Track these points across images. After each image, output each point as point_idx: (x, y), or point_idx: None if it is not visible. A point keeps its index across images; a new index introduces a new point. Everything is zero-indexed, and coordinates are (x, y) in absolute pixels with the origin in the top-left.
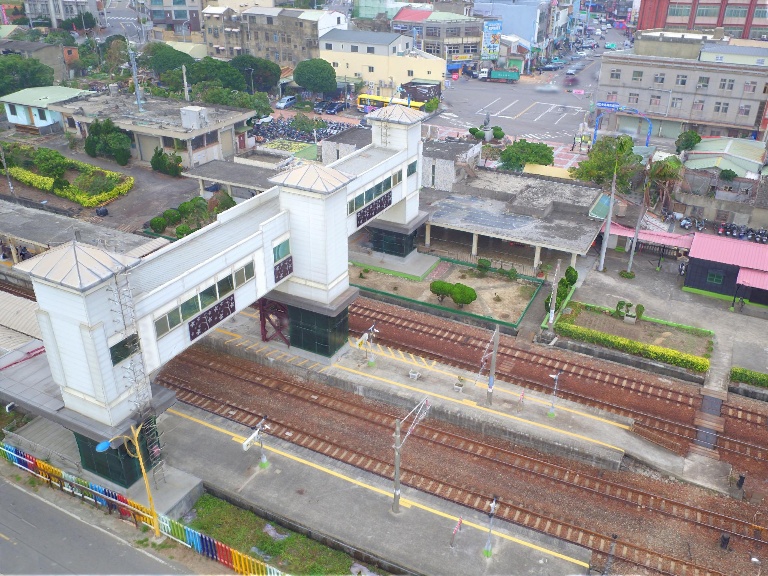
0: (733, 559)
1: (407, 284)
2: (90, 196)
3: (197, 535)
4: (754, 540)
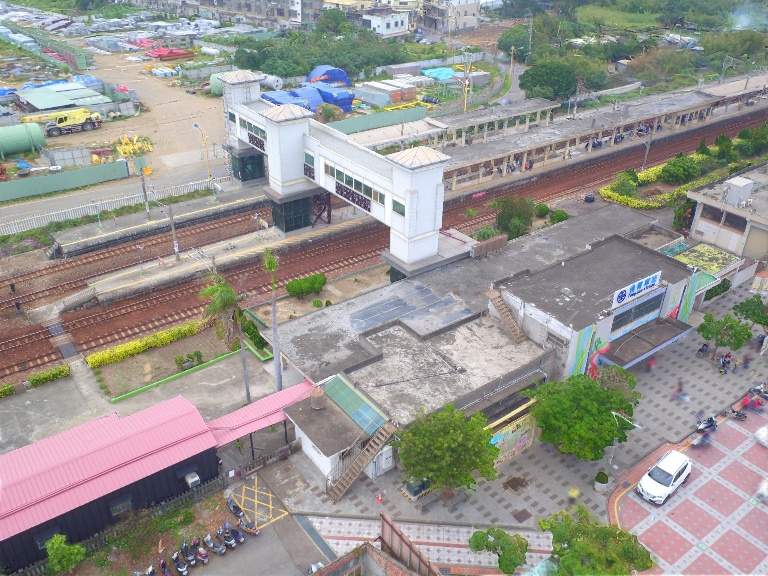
0: (7, 291)
1: (361, 288)
2: (610, 189)
3: (191, 183)
4: (0, 302)
